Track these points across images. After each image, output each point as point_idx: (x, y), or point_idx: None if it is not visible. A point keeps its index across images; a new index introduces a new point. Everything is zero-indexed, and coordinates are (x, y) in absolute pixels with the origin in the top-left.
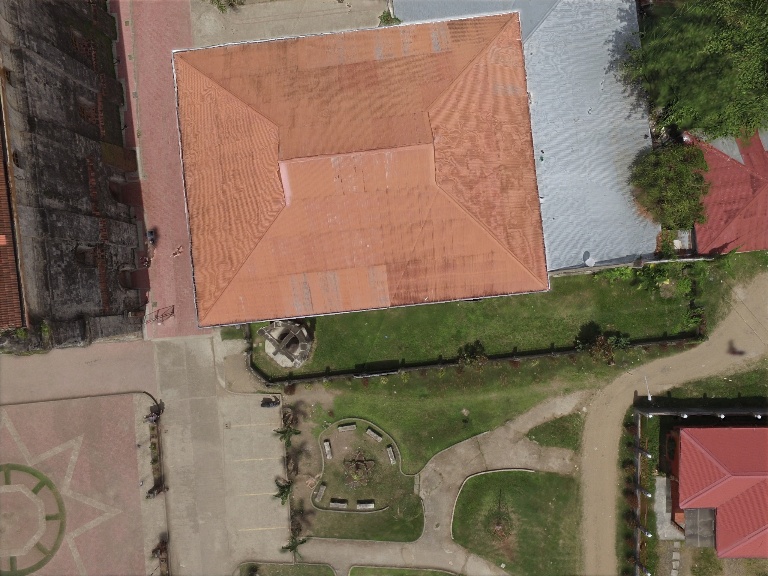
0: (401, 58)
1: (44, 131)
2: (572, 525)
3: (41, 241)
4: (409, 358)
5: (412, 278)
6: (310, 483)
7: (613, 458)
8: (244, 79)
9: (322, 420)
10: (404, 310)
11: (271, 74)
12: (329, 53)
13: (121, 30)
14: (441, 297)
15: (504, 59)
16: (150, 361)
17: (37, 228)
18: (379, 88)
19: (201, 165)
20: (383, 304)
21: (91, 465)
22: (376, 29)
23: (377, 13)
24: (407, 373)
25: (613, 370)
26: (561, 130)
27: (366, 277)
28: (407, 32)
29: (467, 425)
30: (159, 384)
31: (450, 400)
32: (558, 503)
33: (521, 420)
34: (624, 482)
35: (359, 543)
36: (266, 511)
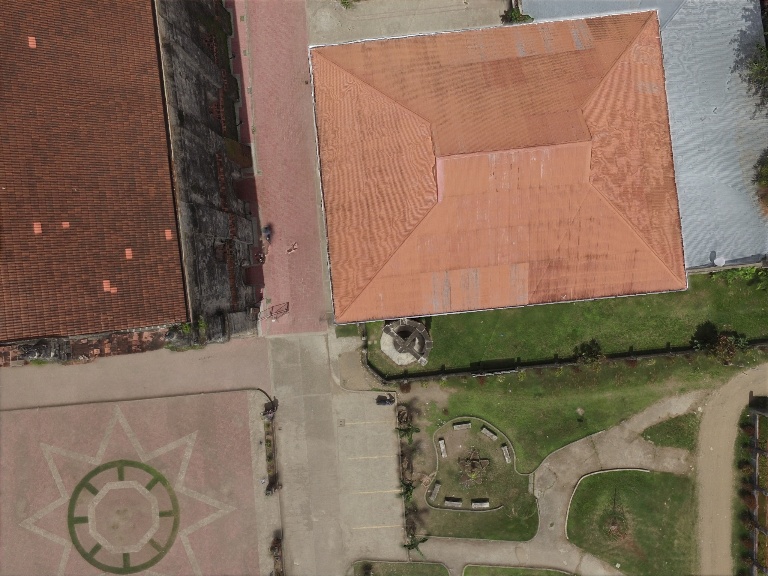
0: (545, 55)
1: (190, 126)
2: (687, 525)
3: (191, 236)
4: (525, 357)
5: (553, 276)
6: (424, 481)
7: (729, 458)
8: (387, 75)
9: (436, 418)
10: (520, 309)
11: (414, 70)
12: (470, 50)
13: (236, 25)
14: (579, 295)
15: (644, 57)
16: (264, 358)
17: (189, 223)
18: (527, 85)
19: (341, 161)
20: (521, 302)
21: (205, 462)
22: (514, 26)
23: (494, 10)
24: (524, 372)
25: (729, 370)
26: (688, 129)
27: (508, 275)
28: (546, 29)
29: (582, 424)
30: (273, 381)
31: (565, 399)
32: (673, 503)
33: (636, 420)
34: (740, 482)
35: (473, 542)
36: (380, 509)
